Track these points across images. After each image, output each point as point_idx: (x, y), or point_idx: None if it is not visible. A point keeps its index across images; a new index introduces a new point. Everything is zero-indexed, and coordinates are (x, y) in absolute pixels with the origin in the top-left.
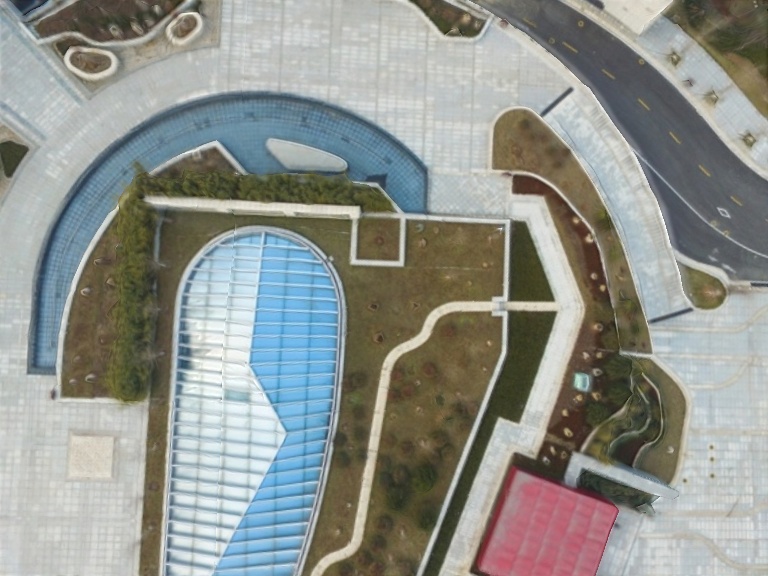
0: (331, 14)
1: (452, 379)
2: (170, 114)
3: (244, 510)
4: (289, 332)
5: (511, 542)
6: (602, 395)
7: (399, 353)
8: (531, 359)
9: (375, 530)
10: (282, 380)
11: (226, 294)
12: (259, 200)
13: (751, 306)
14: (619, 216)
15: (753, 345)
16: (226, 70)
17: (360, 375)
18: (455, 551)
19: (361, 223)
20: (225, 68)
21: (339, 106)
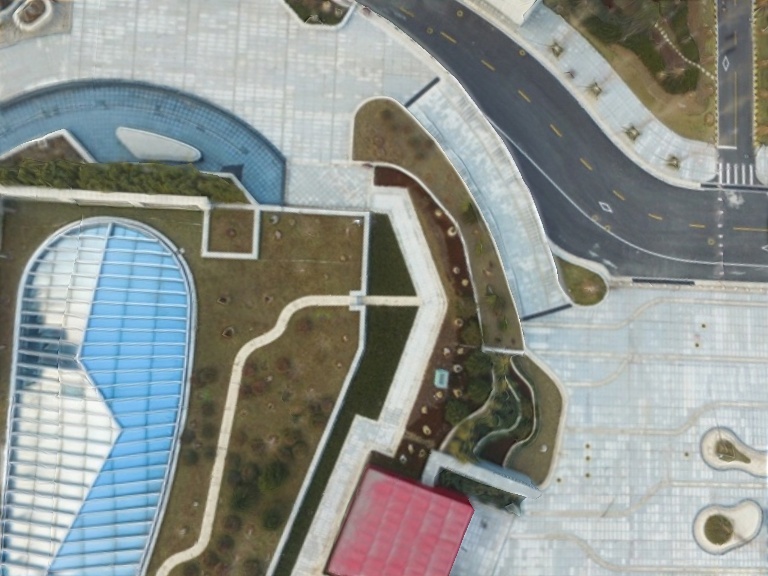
0: (188, 0)
1: (305, 375)
2: (17, 101)
3: (78, 509)
4: (131, 326)
5: (361, 542)
6: (463, 392)
7: (252, 348)
8: (390, 355)
9: (222, 530)
10: (119, 375)
11: (67, 286)
12: (100, 190)
13: (632, 302)
14: (491, 209)
15: (633, 342)
16: (77, 57)
17: (210, 370)
18: (308, 551)
19: (213, 214)
20: (76, 55)
21: (194, 95)
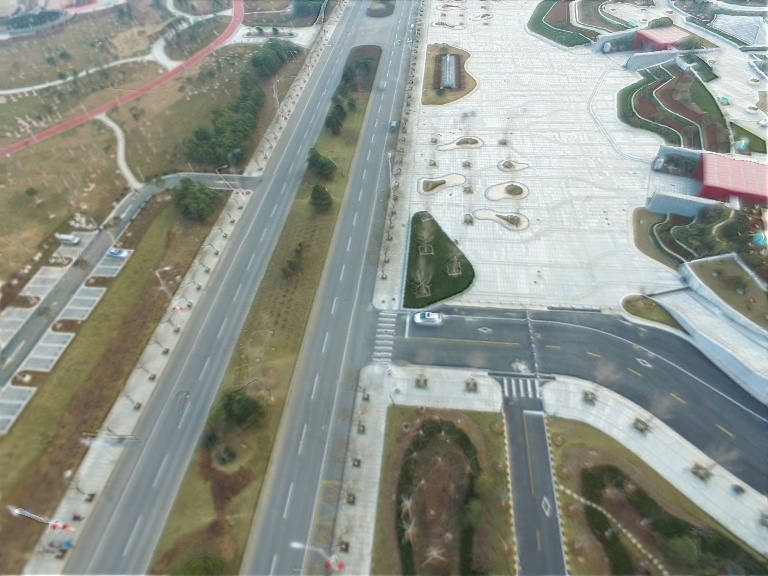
0: None
1: None
2: None
3: None
4: None
5: (764, 174)
6: None
7: None
8: None
9: None
10: None
11: None
12: None
13: (597, 297)
14: (766, 350)
15: (589, 274)
16: None
17: None
18: None
19: None
20: None
21: None
